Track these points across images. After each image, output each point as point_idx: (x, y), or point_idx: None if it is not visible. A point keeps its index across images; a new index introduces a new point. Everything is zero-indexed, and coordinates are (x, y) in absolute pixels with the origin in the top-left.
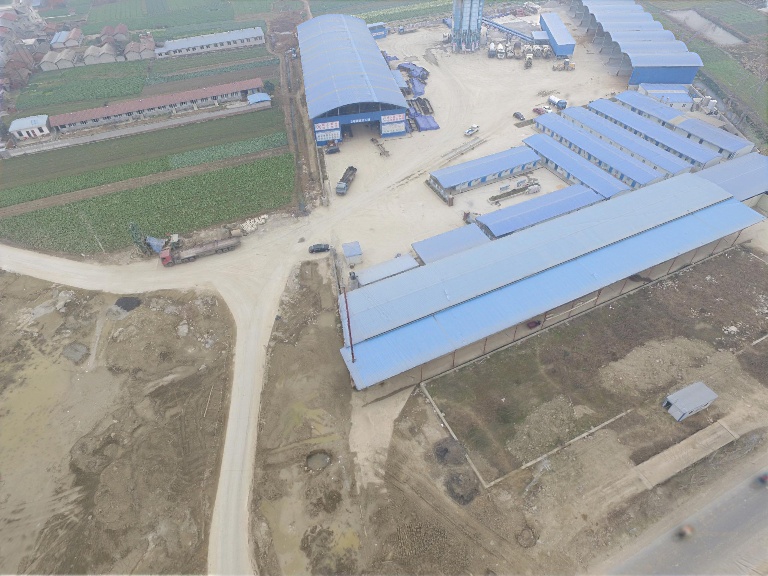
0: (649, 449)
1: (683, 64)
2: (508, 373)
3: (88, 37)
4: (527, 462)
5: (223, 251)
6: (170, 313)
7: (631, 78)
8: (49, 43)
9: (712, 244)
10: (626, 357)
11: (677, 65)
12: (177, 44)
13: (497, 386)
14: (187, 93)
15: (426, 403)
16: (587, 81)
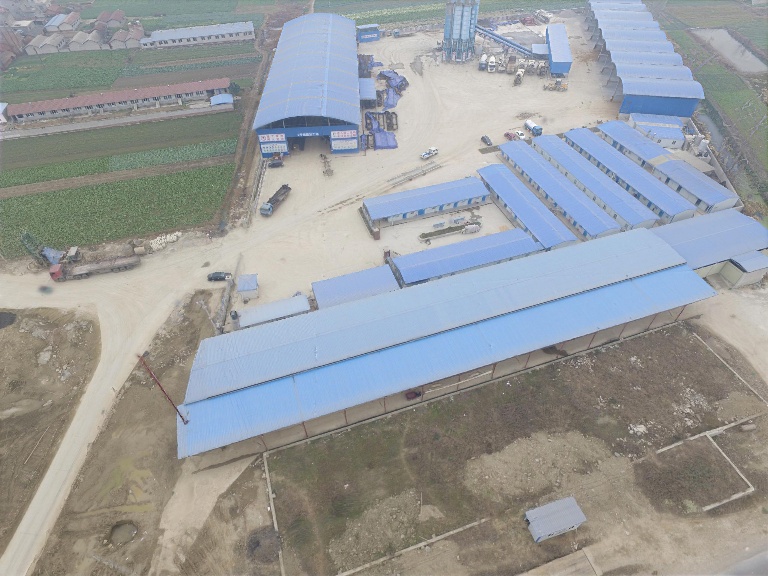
0: (489, 574)
1: (681, 95)
2: (363, 453)
3: (86, 21)
4: (344, 571)
5: (120, 270)
6: (37, 337)
7: (622, 106)
8: (43, 26)
9: (653, 316)
10: (503, 450)
11: (674, 96)
12: (164, 35)
13: (346, 468)
14: (150, 89)
15: (261, 478)
16: (576, 105)
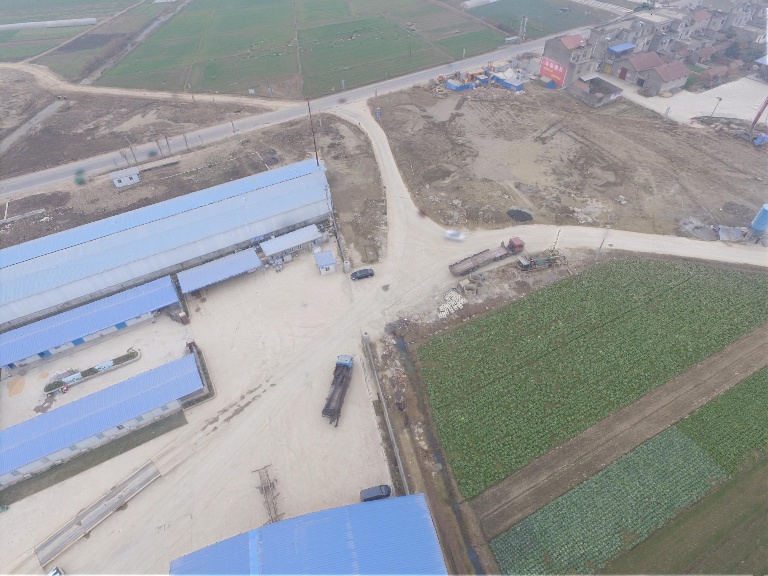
0: (167, 166)
1: None
2: None
3: None
4: None
5: None
6: None
7: None
8: None
9: None
10: None
11: None
12: None
13: None
14: None
15: None
16: None
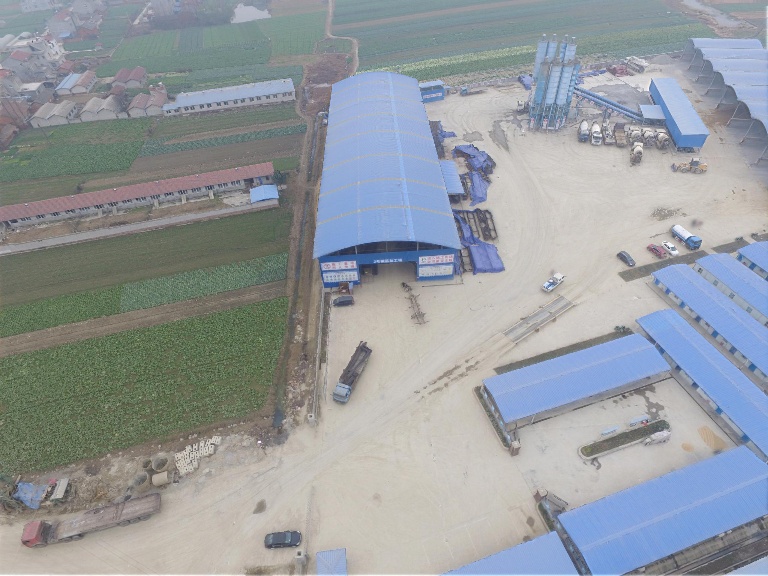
0: None
1: None
2: None
3: (102, 80)
4: None
5: (130, 522)
6: None
7: None
8: (54, 89)
9: None
10: None
11: None
12: (190, 99)
13: None
14: (175, 181)
15: None
16: (727, 195)
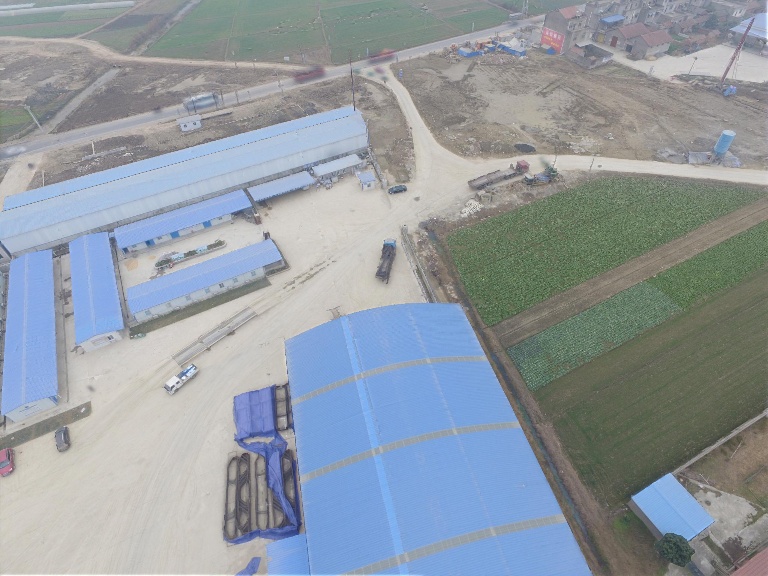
0: (222, 116)
1: None
2: None
3: None
4: None
5: None
6: None
7: None
8: None
9: None
10: None
11: None
12: None
13: None
14: None
15: None
16: None
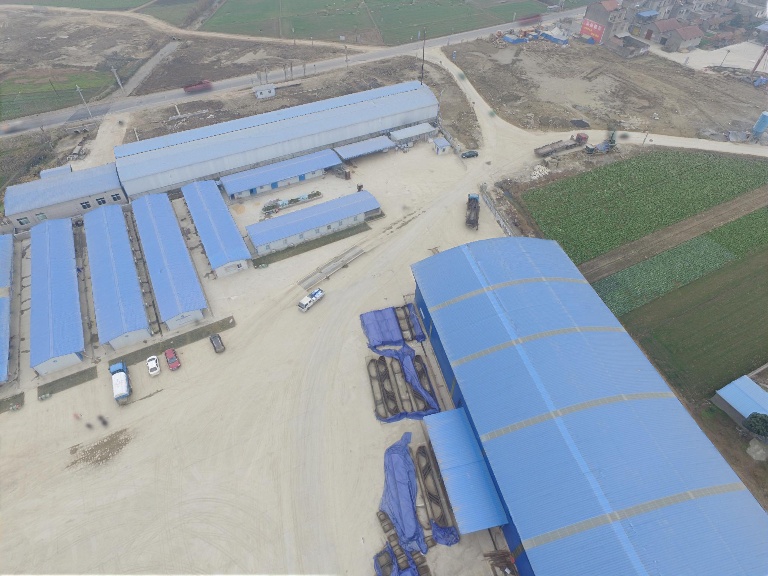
0: None
1: None
2: None
3: None
4: None
5: None
6: None
7: None
8: None
9: None
10: None
11: None
12: None
13: None
14: None
15: None
16: None
